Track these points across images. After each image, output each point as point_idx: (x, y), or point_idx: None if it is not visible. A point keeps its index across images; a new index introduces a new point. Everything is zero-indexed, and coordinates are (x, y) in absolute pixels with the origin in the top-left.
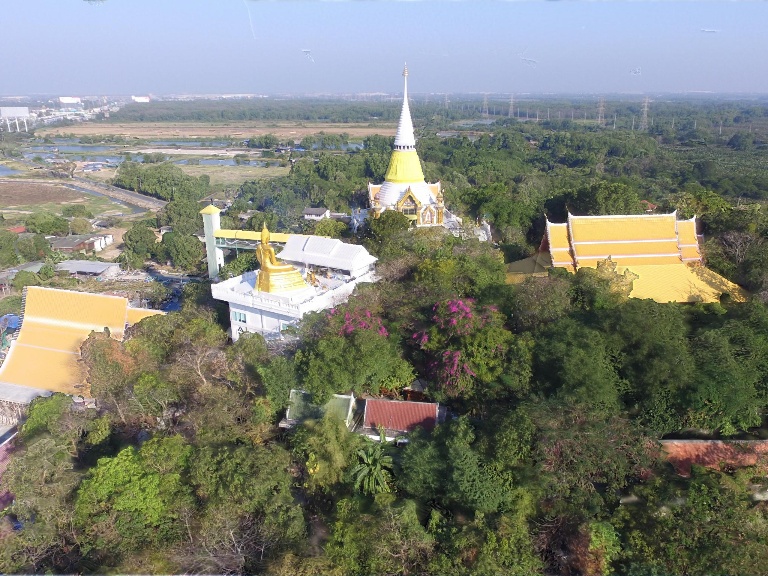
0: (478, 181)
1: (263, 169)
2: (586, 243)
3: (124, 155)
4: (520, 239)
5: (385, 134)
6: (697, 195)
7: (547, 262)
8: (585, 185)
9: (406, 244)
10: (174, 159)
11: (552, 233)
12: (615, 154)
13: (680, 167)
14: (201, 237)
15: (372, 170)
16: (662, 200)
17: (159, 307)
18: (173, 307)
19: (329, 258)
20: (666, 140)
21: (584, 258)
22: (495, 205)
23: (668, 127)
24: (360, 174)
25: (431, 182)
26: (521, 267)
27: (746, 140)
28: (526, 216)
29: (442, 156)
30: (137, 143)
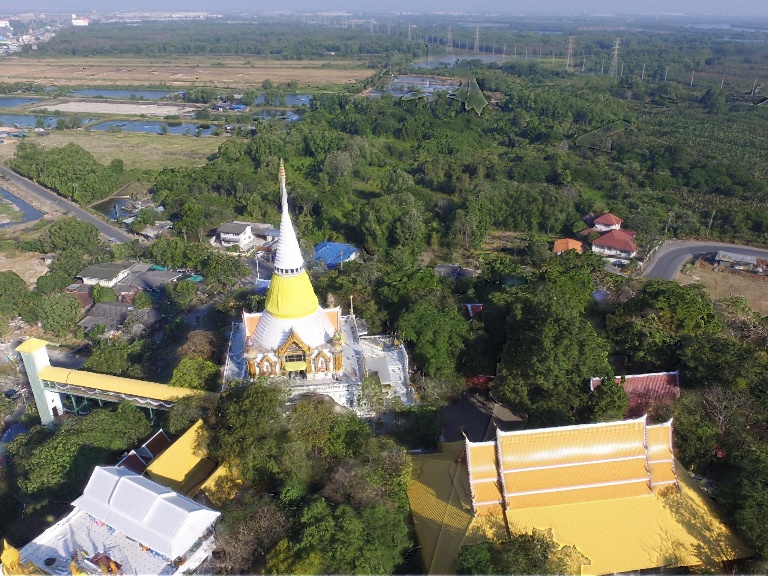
0: (428, 171)
1: (192, 140)
2: (520, 470)
3: (39, 114)
4: (447, 372)
5: (339, 79)
6: (672, 304)
7: (466, 494)
8: (535, 272)
9: (274, 452)
10: (95, 121)
11: (473, 457)
12: (581, 119)
13: (649, 144)
14: (86, 279)
15: (312, 149)
16: (629, 202)
17: (2, 423)
18: (12, 435)
19: (141, 527)
20: (636, 95)
21: (517, 495)
22: (417, 319)
23: (638, 79)
24: (299, 153)
25: (377, 165)
26: (434, 480)
27: (719, 98)
28: (456, 334)
29: (393, 124)
30: (58, 94)
